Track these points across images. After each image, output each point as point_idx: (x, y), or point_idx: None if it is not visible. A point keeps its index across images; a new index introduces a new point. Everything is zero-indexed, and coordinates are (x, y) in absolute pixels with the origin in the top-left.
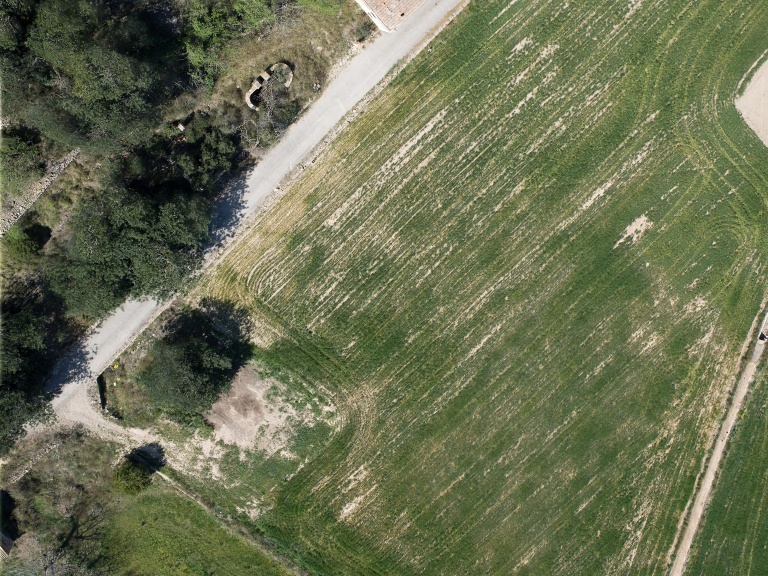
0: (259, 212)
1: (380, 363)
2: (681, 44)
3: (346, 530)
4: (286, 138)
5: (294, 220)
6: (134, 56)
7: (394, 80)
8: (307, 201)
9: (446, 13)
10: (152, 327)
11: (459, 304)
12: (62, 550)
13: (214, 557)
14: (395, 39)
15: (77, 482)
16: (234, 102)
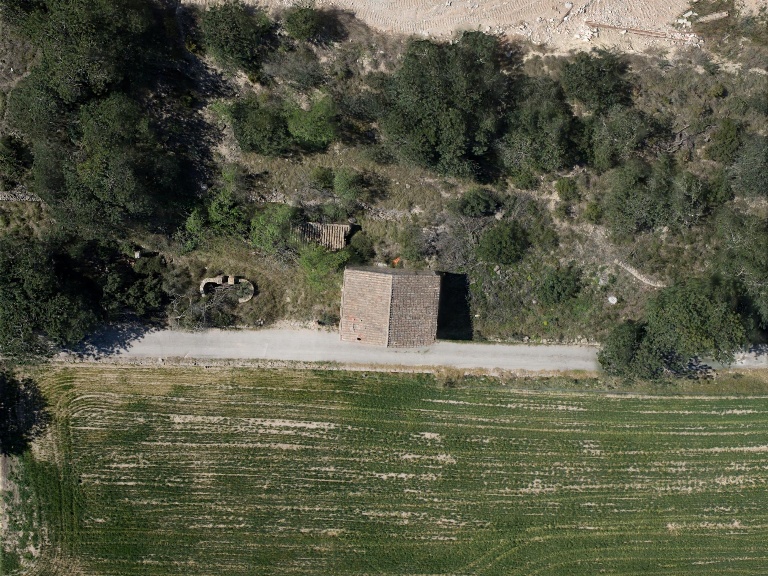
0: (133, 362)
1: (106, 556)
2: (542, 547)
3: None
4: (203, 334)
5: (153, 391)
6: (150, 183)
7: (319, 370)
8: (176, 388)
9: (398, 364)
10: None
11: (208, 571)
12: None
13: None
14: (346, 345)
15: None
16: (193, 275)
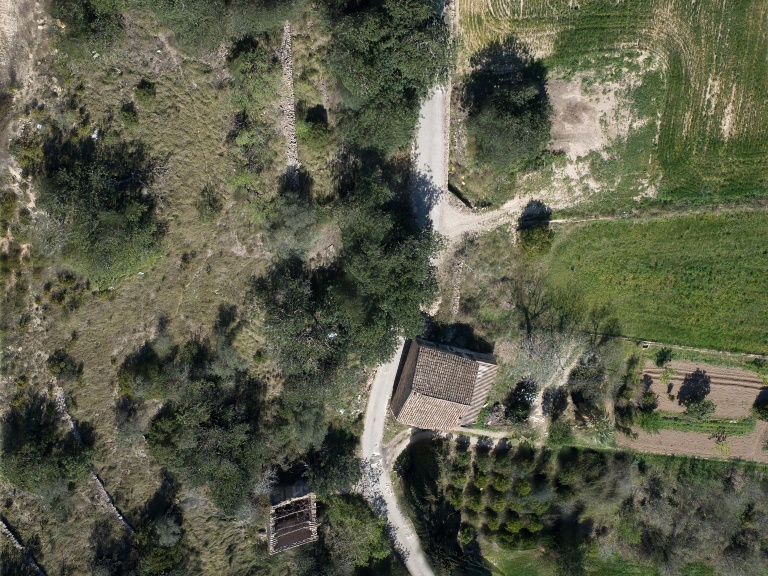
0: None
1: None
2: None
3: (738, 143)
4: None
5: None
6: None
7: None
8: None
9: None
10: (453, 115)
11: None
12: (531, 335)
13: (647, 250)
14: None
15: (499, 277)
16: None
